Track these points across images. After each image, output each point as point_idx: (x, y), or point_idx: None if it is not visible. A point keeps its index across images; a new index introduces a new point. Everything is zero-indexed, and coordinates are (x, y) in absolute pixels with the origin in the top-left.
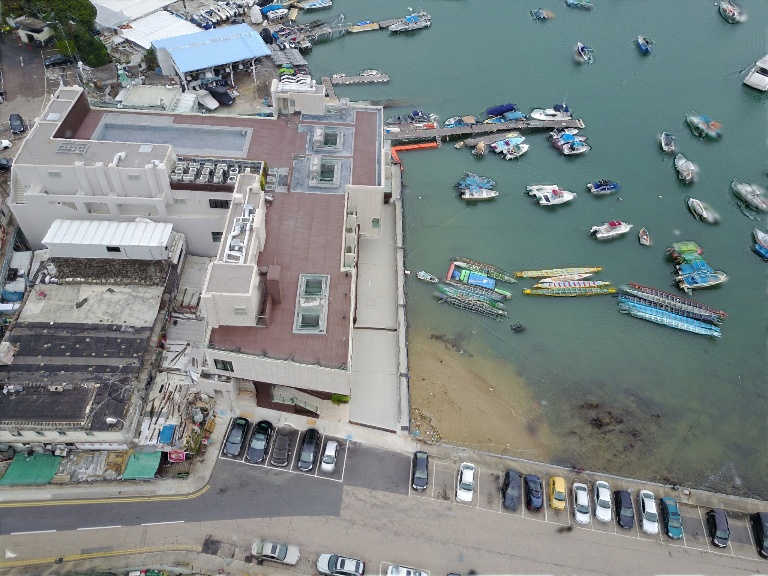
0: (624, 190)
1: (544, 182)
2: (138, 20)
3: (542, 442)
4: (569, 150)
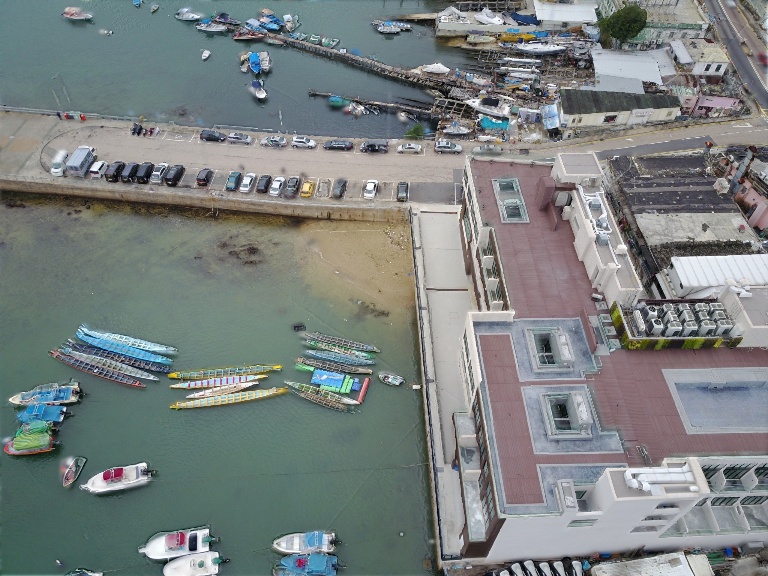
0: None
1: None
2: None
3: (303, 238)
4: None
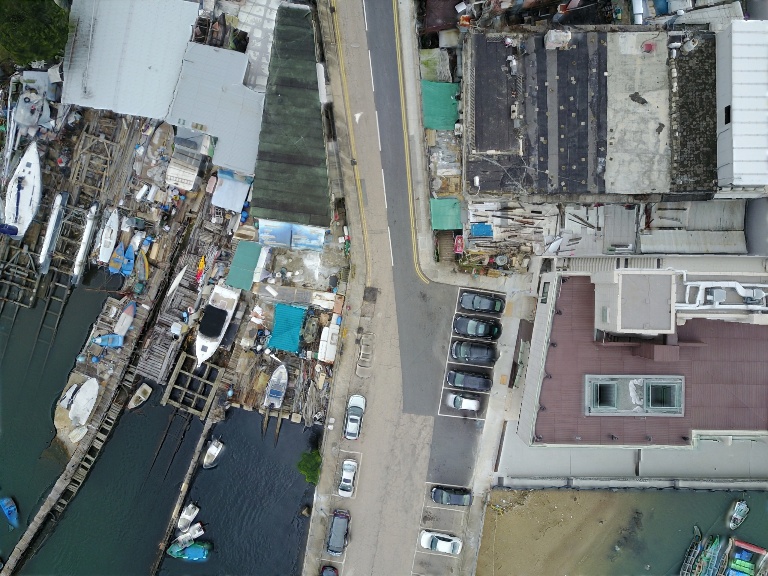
0: None
1: None
2: None
3: None
4: None
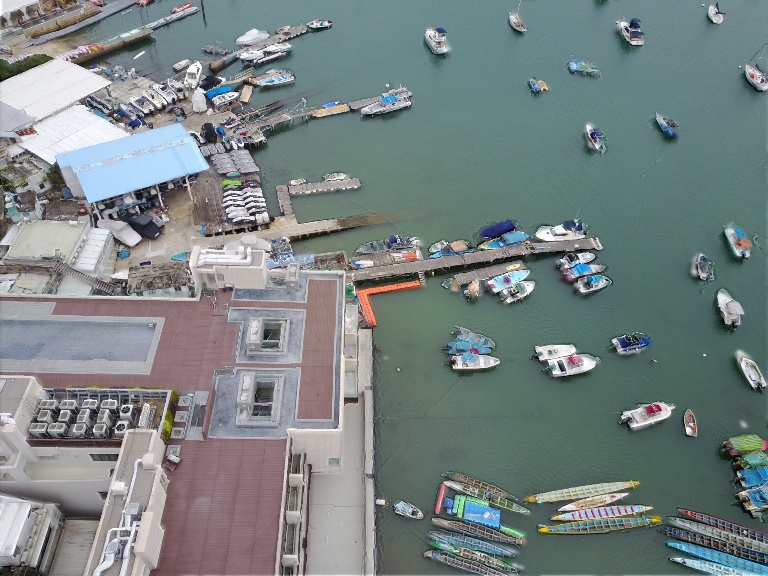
0: (658, 347)
1: (557, 338)
2: (45, 120)
3: None
4: (585, 286)
